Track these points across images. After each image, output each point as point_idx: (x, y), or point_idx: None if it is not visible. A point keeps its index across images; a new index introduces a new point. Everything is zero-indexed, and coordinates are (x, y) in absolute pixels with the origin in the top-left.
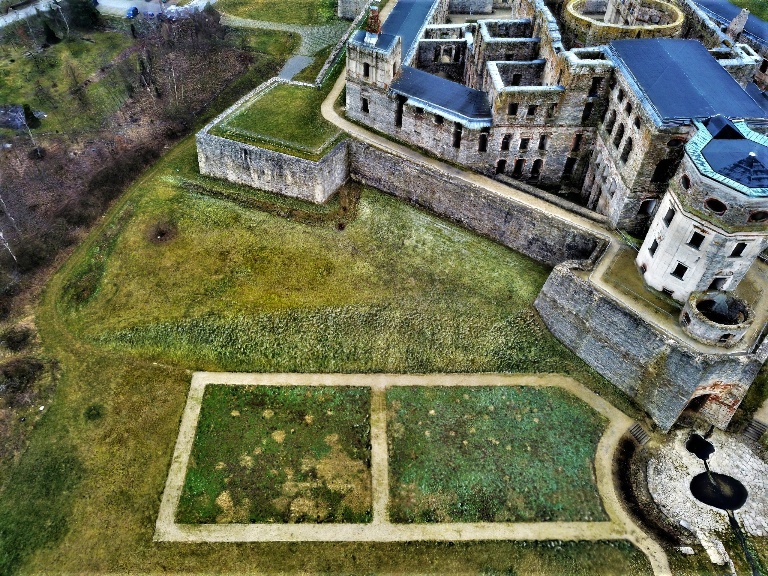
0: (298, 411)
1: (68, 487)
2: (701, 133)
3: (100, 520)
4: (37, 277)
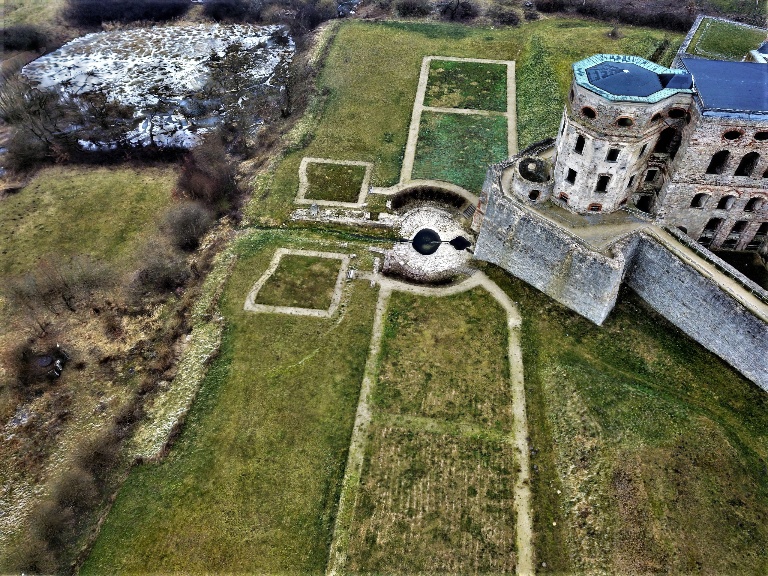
0: (490, 89)
1: (451, 37)
2: (663, 68)
3: (435, 44)
4: (575, 15)
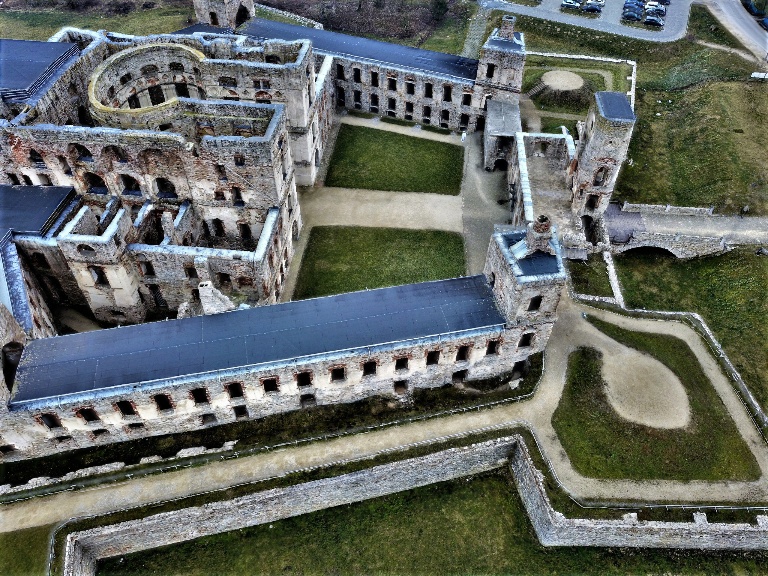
0: None
1: None
2: None
3: None
4: (190, 4)
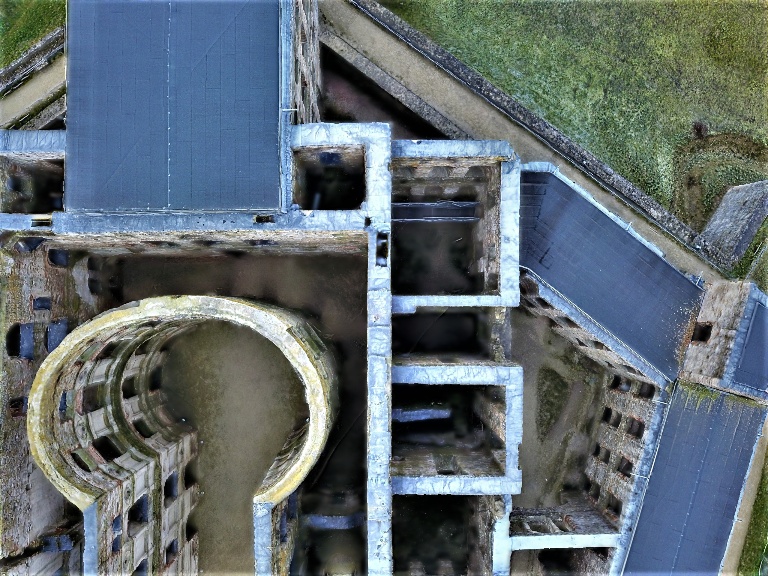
0: None
1: None
2: None
3: None
4: None
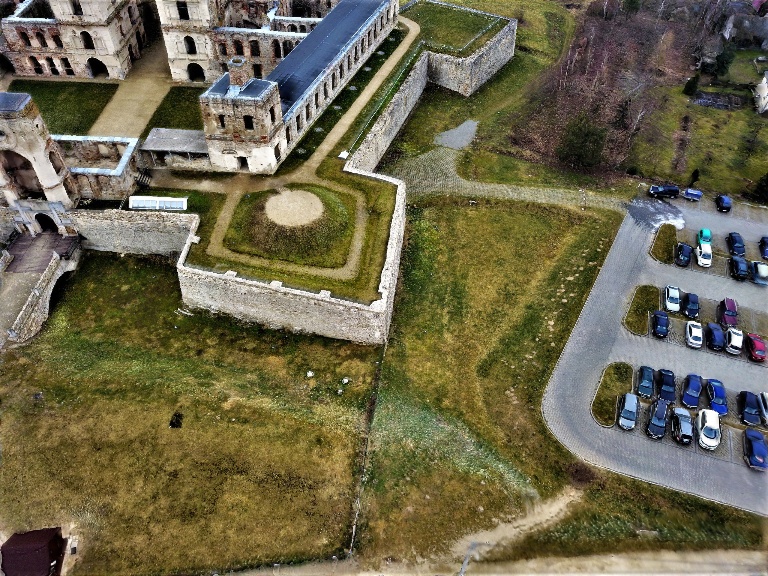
0: None
1: None
2: None
3: None
4: None
